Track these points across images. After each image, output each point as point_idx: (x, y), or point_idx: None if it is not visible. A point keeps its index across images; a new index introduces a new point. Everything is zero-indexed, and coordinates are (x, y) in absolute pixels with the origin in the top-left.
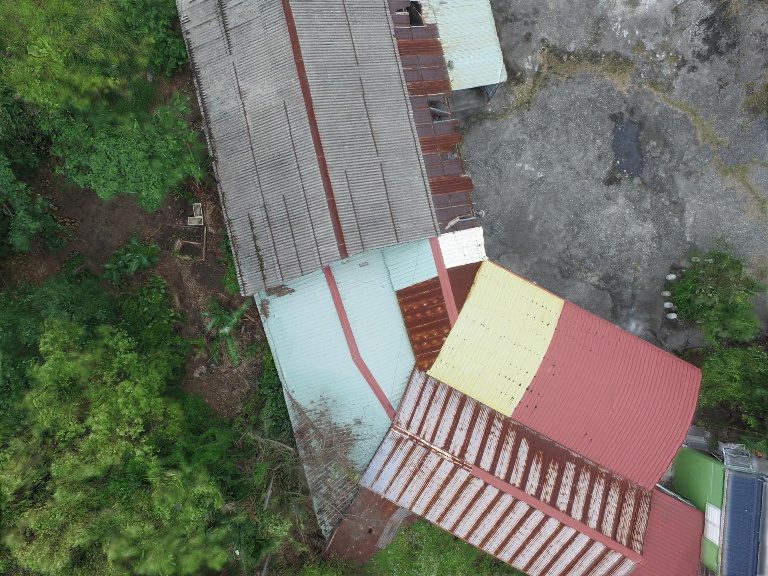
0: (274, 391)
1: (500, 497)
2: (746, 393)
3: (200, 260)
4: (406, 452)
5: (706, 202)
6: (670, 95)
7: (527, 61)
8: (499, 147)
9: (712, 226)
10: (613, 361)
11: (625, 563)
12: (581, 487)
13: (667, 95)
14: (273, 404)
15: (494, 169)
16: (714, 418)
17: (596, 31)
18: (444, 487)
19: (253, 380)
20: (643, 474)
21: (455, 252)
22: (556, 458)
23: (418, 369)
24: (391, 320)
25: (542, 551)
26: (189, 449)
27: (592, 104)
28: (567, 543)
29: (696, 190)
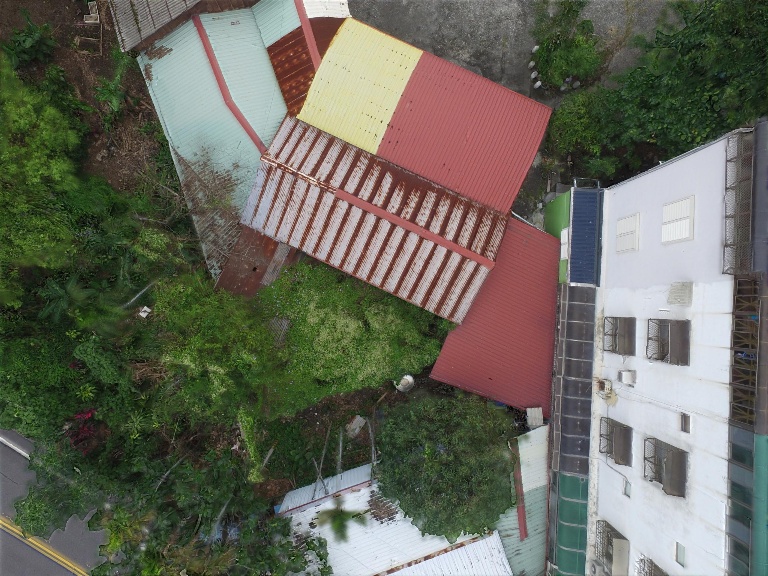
0: (169, 165)
1: (364, 218)
2: (595, 130)
3: (98, 55)
4: (277, 182)
5: None
6: None
7: None
8: None
9: (573, 2)
10: (467, 98)
11: (481, 272)
12: (440, 210)
13: None
14: (168, 176)
15: None
16: (581, 177)
17: None
18: (315, 215)
19: (152, 163)
20: (498, 199)
21: (317, 5)
22: (418, 188)
23: (289, 115)
24: (263, 74)
25: (408, 270)
26: (79, 191)
27: None
28: (428, 258)
29: None
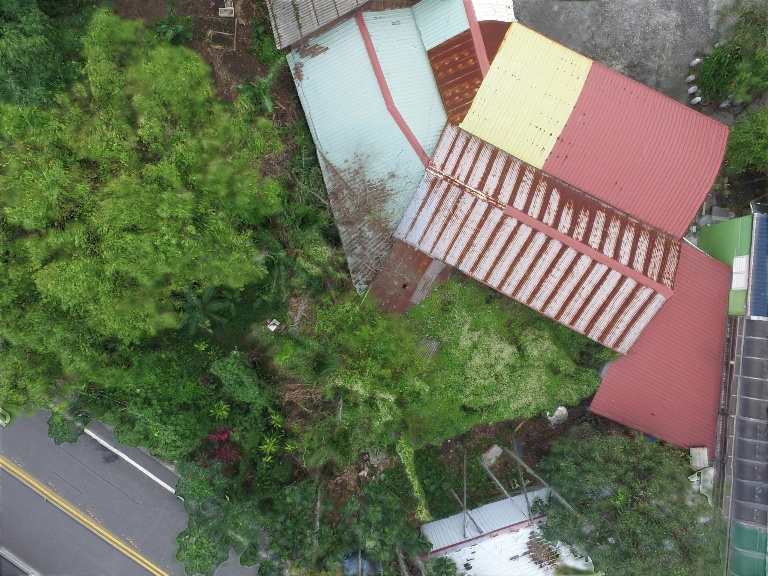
0: (306, 170)
1: (533, 237)
2: None
3: (231, 50)
4: (440, 195)
5: None
6: None
7: None
8: None
9: (735, 14)
10: (642, 113)
11: (656, 300)
12: (612, 232)
13: None
14: (305, 182)
15: None
16: (738, 200)
17: None
18: (478, 231)
19: (284, 166)
20: (672, 222)
21: (486, 7)
22: (587, 206)
23: (450, 123)
24: (423, 78)
25: (574, 295)
26: (228, 196)
27: None
28: (599, 283)
29: None
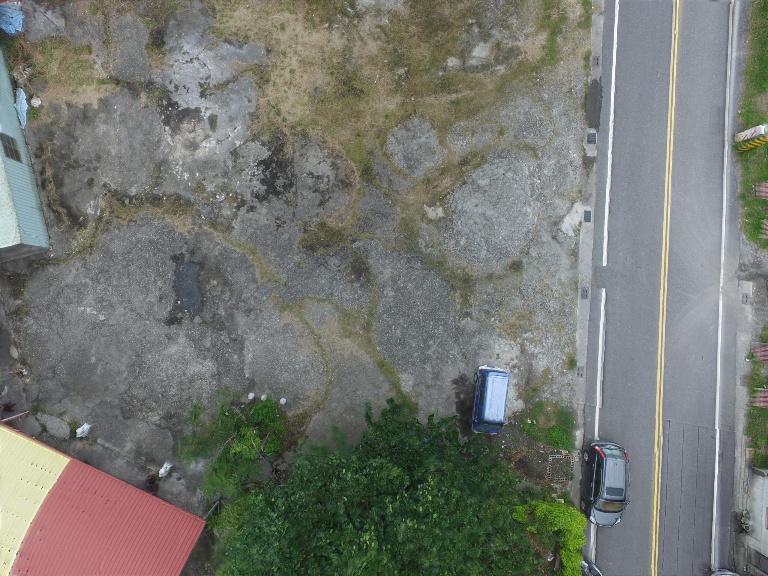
0: None
1: None
2: None
3: None
4: None
5: (264, 338)
6: (230, 235)
7: (89, 206)
8: (61, 292)
9: (270, 362)
10: (105, 521)
11: None
12: None
13: (226, 235)
14: None
15: (56, 314)
16: None
17: (158, 174)
18: None
19: None
20: None
21: None
22: None
23: None
24: None
25: None
26: None
27: (153, 246)
28: None
29: (255, 327)
